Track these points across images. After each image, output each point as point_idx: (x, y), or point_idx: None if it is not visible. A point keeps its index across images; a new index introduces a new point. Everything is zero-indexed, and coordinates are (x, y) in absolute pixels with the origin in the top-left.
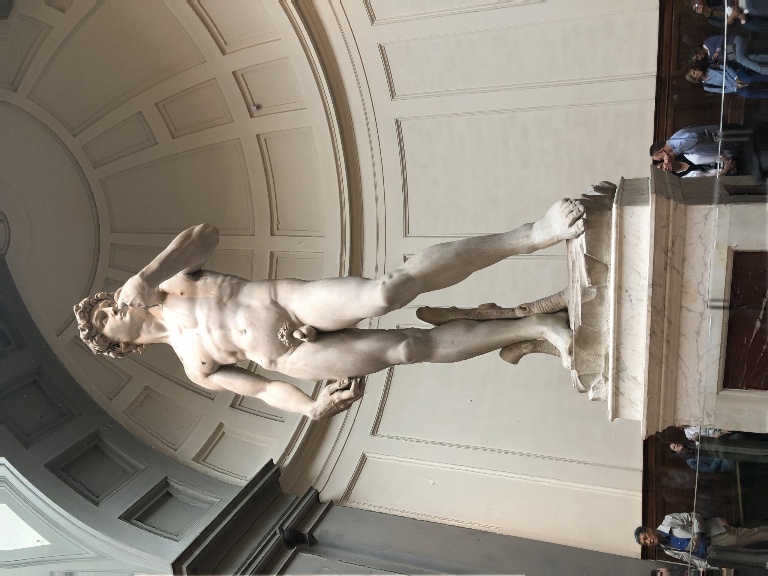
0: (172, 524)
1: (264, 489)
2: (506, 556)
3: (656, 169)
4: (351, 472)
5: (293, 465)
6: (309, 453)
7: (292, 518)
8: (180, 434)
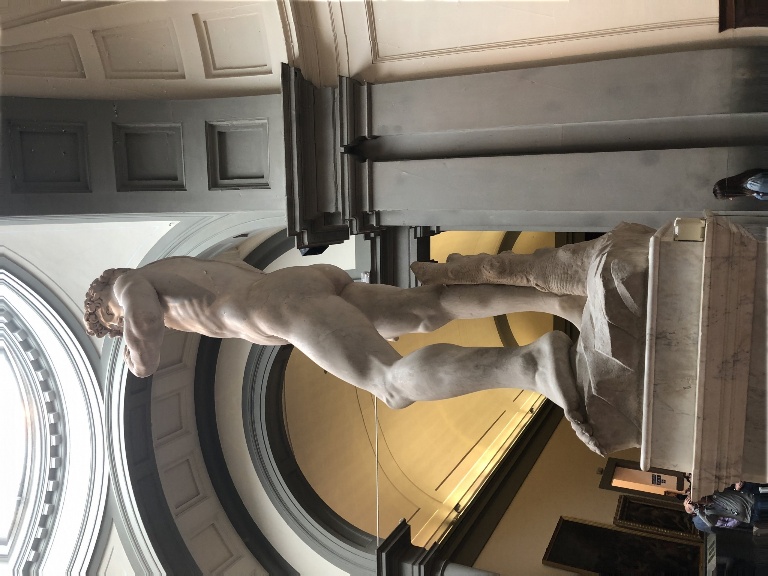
0: (249, 164)
1: (299, 101)
2: (566, 97)
3: (716, 260)
4: (364, 19)
5: (303, 43)
6: (307, 15)
7: (345, 130)
8: (170, 53)
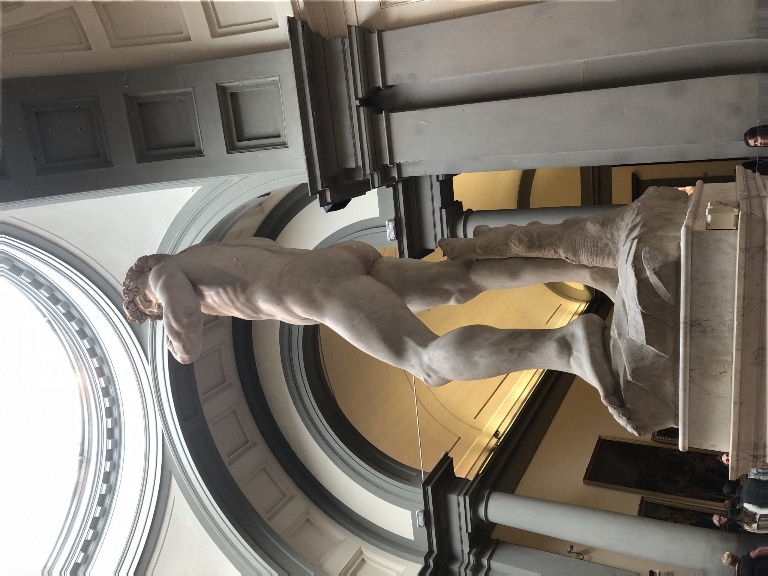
0: (265, 124)
1: (309, 56)
2: (587, 30)
3: (751, 251)
4: None
5: None
6: None
7: (359, 82)
8: (173, 15)
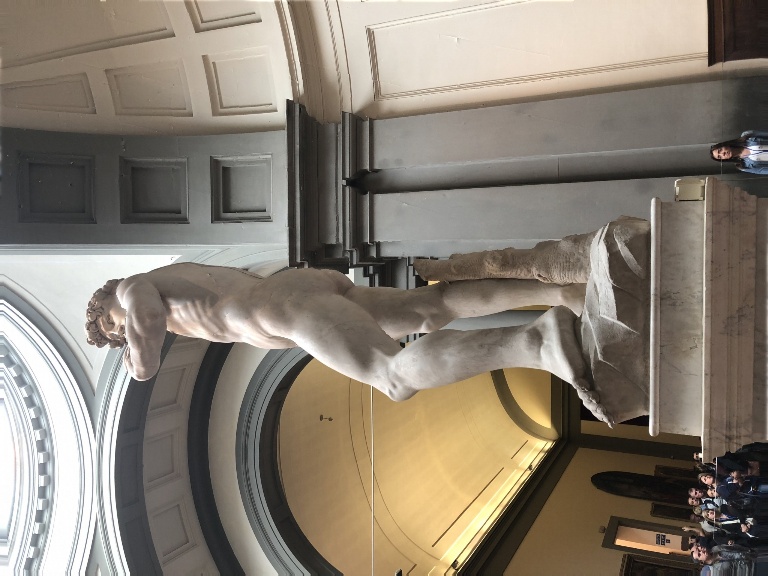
0: (252, 198)
1: (303, 136)
2: (562, 129)
3: (717, 215)
4: (367, 59)
5: (308, 82)
6: (313, 56)
7: (347, 163)
8: (179, 92)
